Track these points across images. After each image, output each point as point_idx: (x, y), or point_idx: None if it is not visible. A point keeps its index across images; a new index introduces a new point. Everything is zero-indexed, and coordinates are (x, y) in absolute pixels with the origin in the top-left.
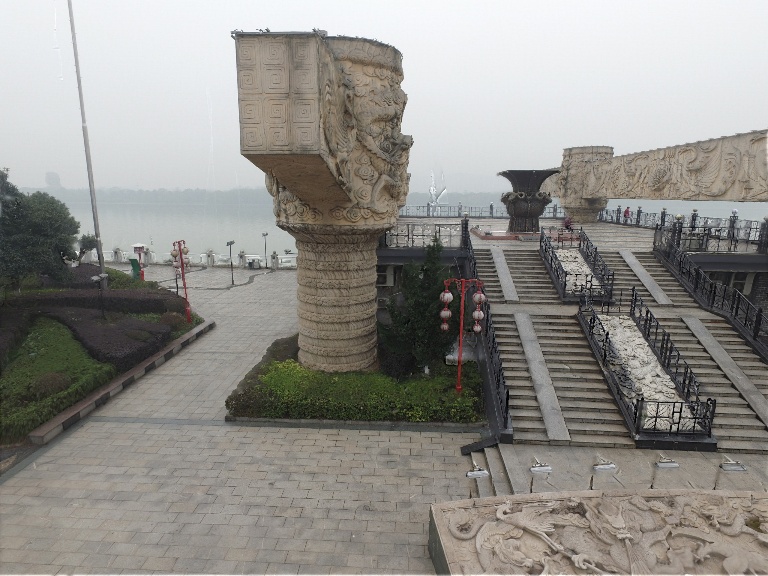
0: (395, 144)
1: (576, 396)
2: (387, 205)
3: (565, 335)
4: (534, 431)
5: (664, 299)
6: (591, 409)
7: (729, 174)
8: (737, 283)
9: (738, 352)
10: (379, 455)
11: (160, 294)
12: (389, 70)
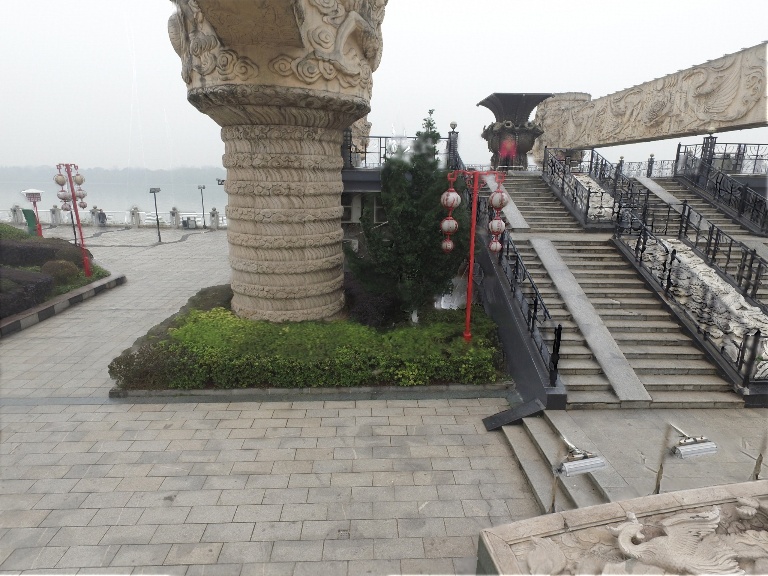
0: None
1: (640, 338)
2: (359, 65)
3: (603, 263)
4: (593, 389)
5: (706, 225)
6: (665, 355)
7: (752, 91)
8: None
9: None
10: (358, 438)
11: (52, 244)
12: None
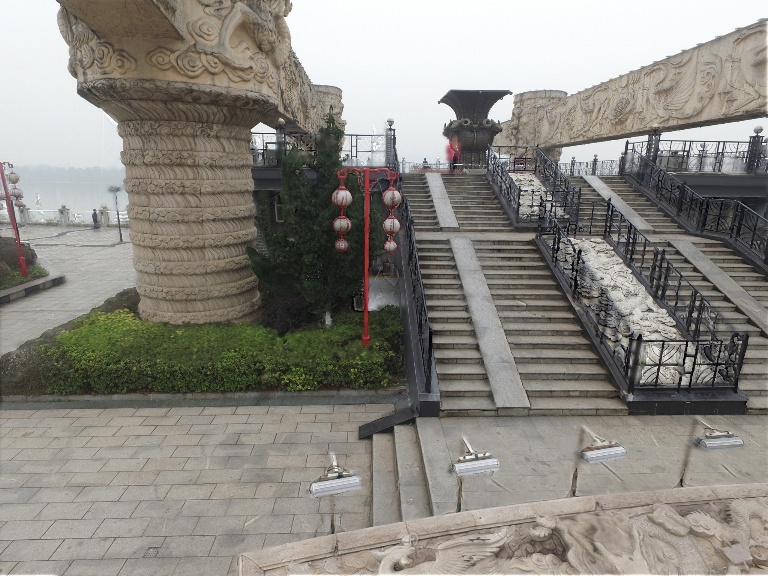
0: None
1: (536, 342)
2: (250, 58)
3: (519, 263)
4: (474, 395)
5: (642, 224)
6: (559, 359)
7: (707, 88)
8: None
9: (746, 280)
10: (219, 446)
11: None
12: None
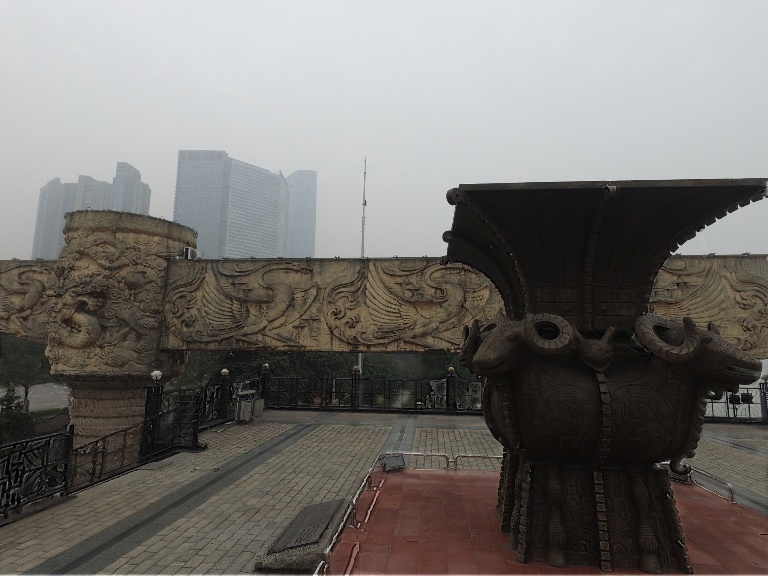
0: None
1: None
2: (51, 351)
3: None
4: None
5: None
6: None
7: None
8: None
9: None
10: None
11: None
12: None
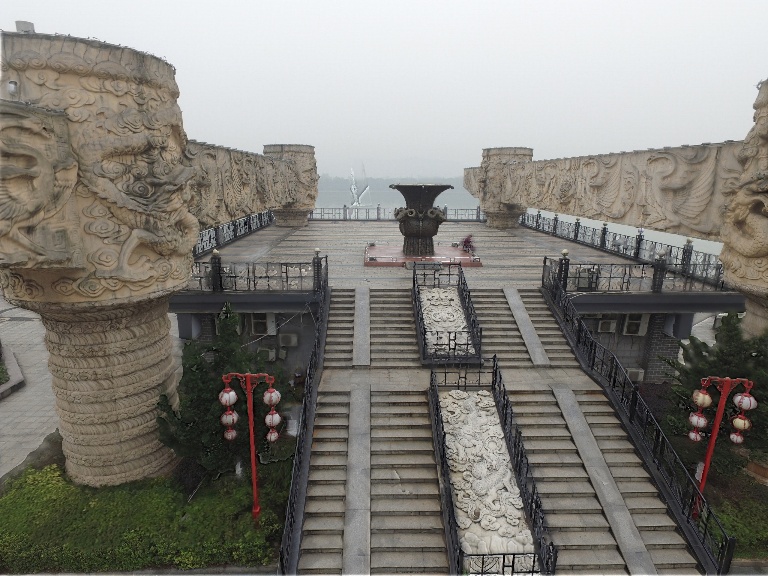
0: (159, 184)
1: (396, 527)
2: (151, 268)
3: (407, 423)
4: None
5: (541, 357)
6: (411, 548)
7: (628, 195)
8: (632, 323)
9: (611, 439)
10: None
11: None
12: (133, 82)
